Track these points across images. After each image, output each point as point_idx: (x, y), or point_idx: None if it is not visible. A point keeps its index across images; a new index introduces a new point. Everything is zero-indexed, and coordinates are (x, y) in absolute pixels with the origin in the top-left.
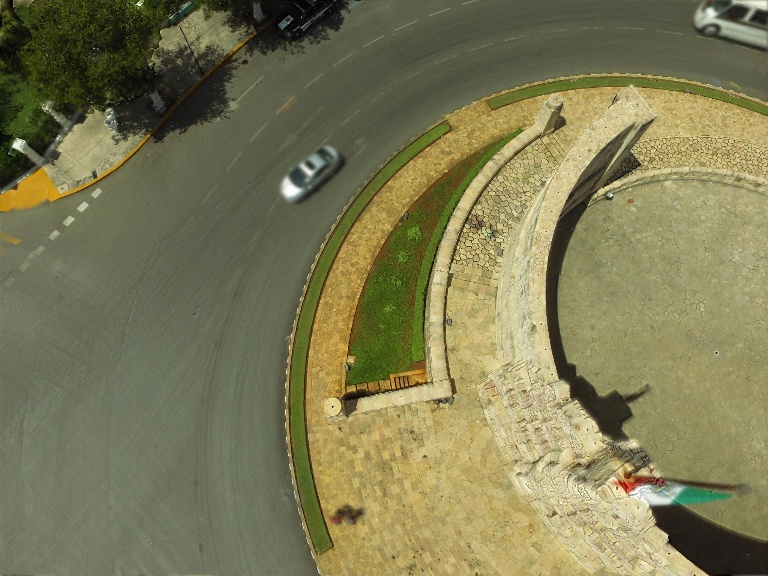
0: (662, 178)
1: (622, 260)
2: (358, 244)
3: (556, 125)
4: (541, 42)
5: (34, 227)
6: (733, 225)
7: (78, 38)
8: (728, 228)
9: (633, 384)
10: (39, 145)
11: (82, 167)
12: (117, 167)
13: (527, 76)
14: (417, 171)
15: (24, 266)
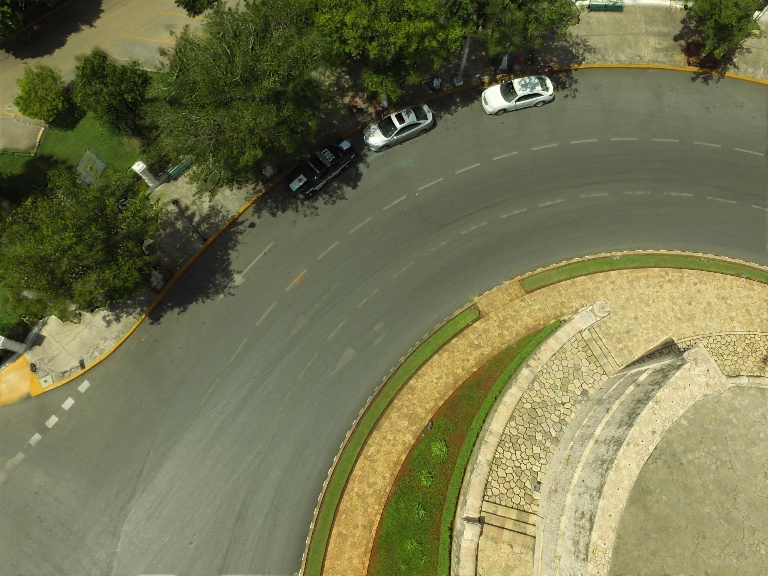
0: None
1: (672, 486)
2: (376, 459)
3: None
4: (580, 209)
5: (13, 429)
6: None
7: (62, 261)
8: None
9: None
10: (20, 333)
11: (68, 355)
12: (107, 355)
13: (565, 250)
14: (442, 368)
15: (0, 478)
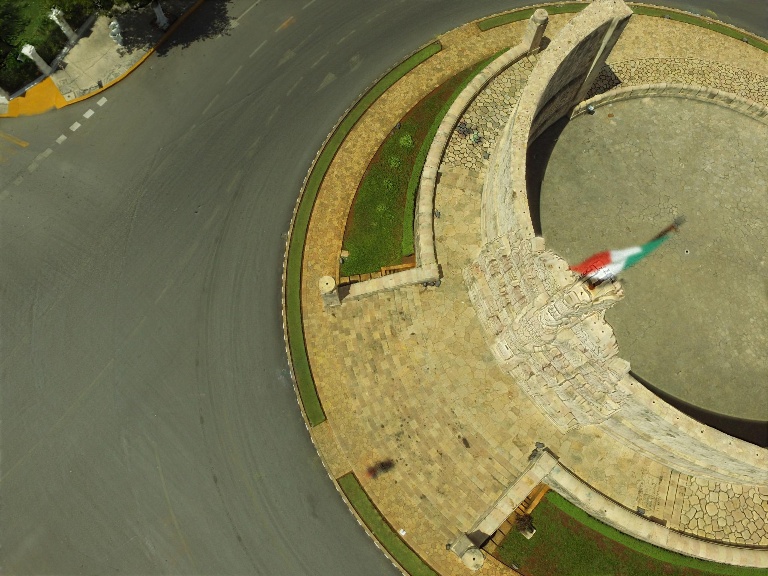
0: (641, 94)
1: (601, 168)
2: (352, 151)
3: (542, 46)
4: None
5: (42, 131)
6: (706, 138)
7: None
8: (701, 141)
9: None
10: (47, 54)
11: (88, 77)
12: (122, 78)
13: (516, 1)
14: (409, 86)
15: (32, 167)
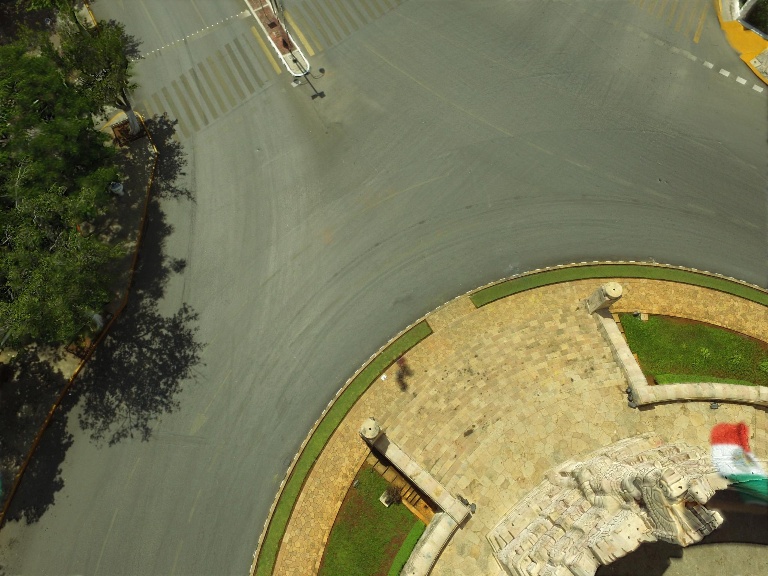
0: None
1: None
2: None
3: None
4: None
5: (712, 49)
6: None
7: None
8: None
9: None
10: None
11: None
12: None
13: None
14: None
15: (675, 49)
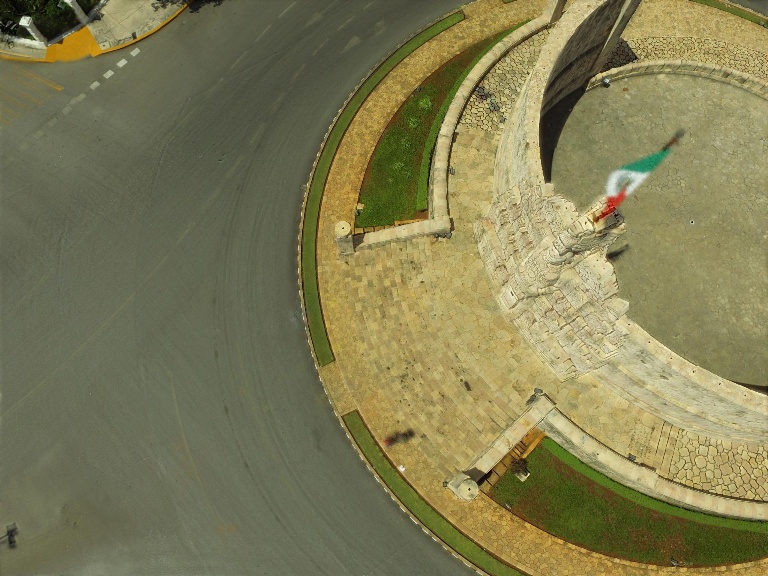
0: (656, 70)
1: (613, 139)
2: (373, 110)
3: None
4: None
5: (77, 77)
6: (717, 116)
7: None
8: (713, 118)
9: (614, 243)
10: (85, 4)
11: (123, 28)
12: (155, 31)
13: None
14: (431, 51)
15: (66, 110)
